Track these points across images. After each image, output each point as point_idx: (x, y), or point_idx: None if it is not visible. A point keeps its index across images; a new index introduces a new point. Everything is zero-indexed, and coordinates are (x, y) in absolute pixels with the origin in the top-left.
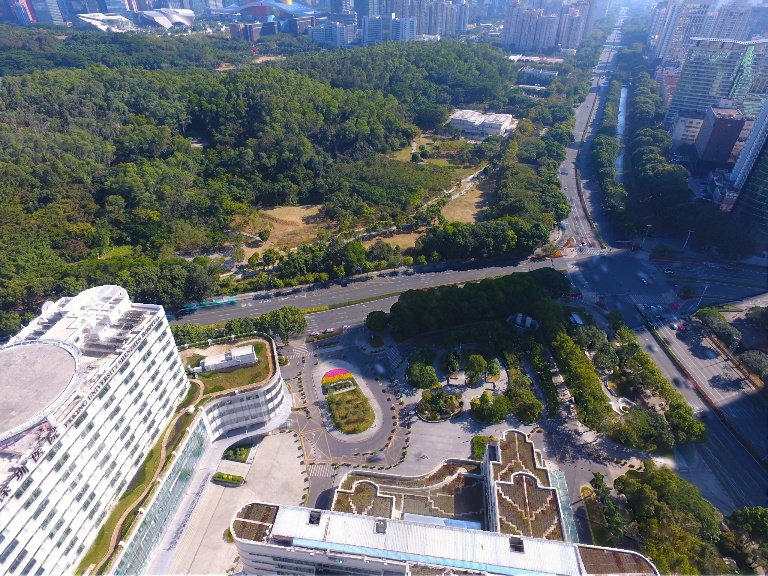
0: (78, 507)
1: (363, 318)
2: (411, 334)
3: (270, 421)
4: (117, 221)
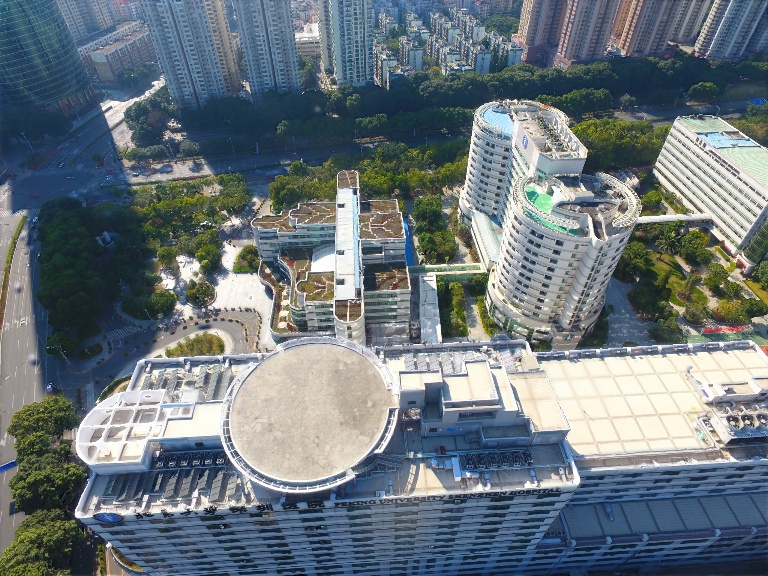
0: None
1: (36, 374)
2: (101, 310)
3: None
4: None
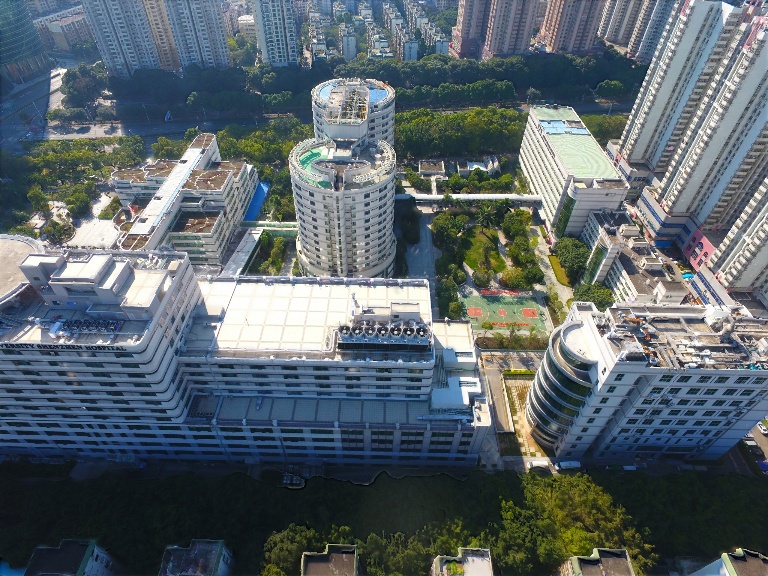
0: None
1: None
2: None
3: None
4: None
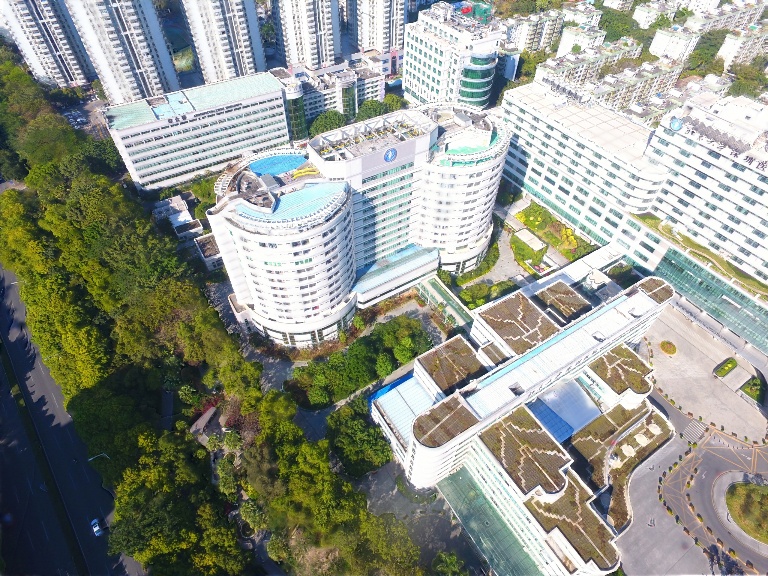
0: (724, 220)
1: None
2: None
3: None
4: None
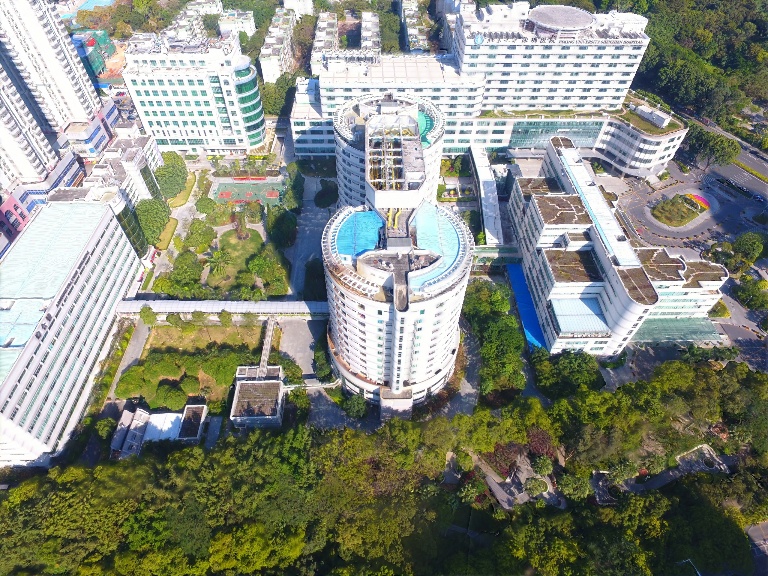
0: (532, 86)
1: None
2: None
3: (629, 169)
4: (732, 45)
